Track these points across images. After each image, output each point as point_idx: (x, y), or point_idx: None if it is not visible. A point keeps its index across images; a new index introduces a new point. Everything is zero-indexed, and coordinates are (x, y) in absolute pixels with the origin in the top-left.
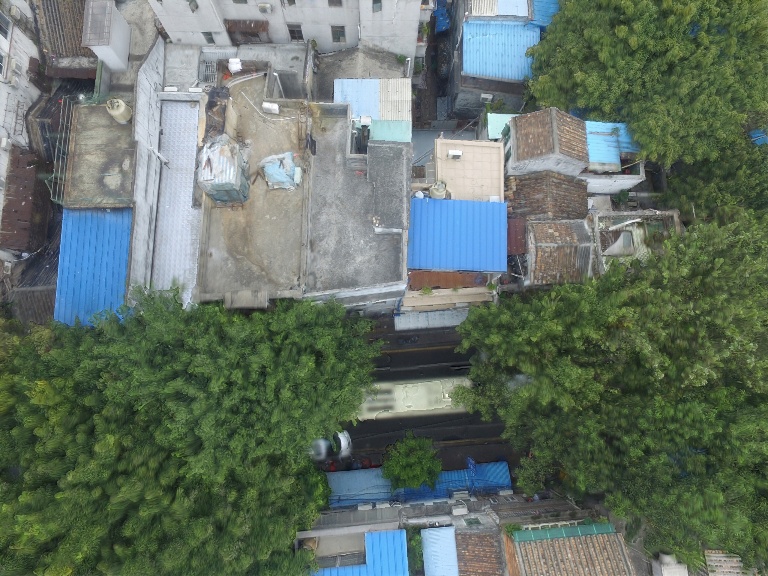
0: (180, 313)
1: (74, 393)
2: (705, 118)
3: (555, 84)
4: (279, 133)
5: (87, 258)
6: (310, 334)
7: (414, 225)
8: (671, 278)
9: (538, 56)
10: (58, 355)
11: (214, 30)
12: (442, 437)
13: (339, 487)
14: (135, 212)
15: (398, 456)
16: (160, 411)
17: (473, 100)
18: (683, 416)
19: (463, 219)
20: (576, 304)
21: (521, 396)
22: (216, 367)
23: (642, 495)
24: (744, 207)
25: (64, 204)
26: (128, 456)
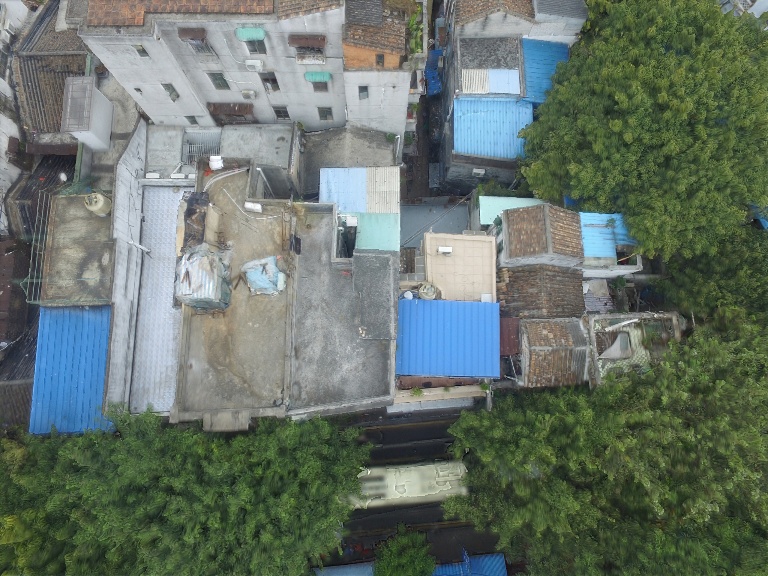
0: (156, 442)
1: (46, 524)
2: (703, 213)
3: (548, 170)
4: (262, 233)
5: (65, 359)
6: (293, 457)
7: (403, 328)
8: None
9: (530, 139)
10: (29, 483)
11: (197, 114)
12: (437, 518)
13: None
14: (114, 314)
15: (390, 555)
16: (135, 547)
17: (465, 173)
18: (685, 554)
19: (454, 321)
20: (571, 423)
21: (515, 522)
22: (192, 510)
23: None
24: (745, 306)
25: (41, 303)
26: None
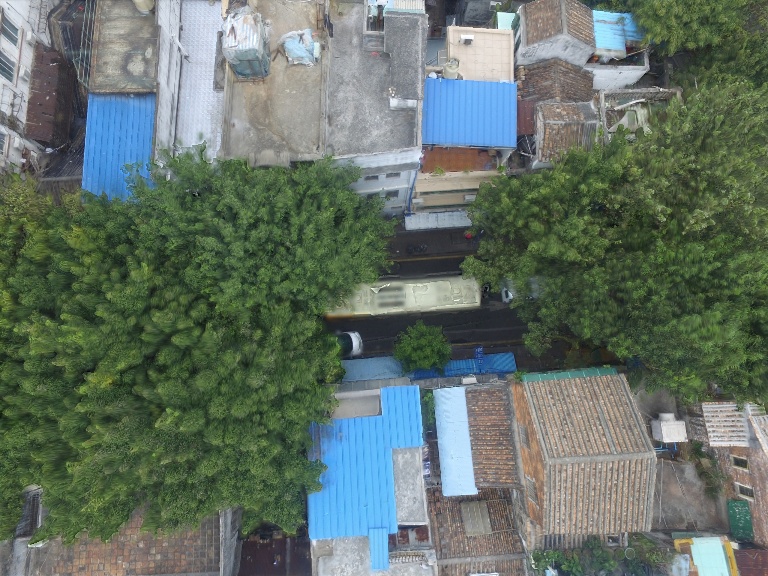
0: (207, 165)
1: (106, 245)
2: (708, 3)
3: None
4: (298, 14)
5: (112, 140)
6: (330, 192)
7: (428, 103)
8: (674, 141)
9: None
10: (90, 209)
11: None
12: (450, 340)
13: (352, 374)
14: (159, 93)
15: (409, 340)
16: (189, 257)
17: (482, 10)
18: (684, 257)
19: (475, 98)
20: (583, 165)
21: (530, 250)
22: (244, 206)
23: (644, 335)
24: None
25: (90, 88)
26: (160, 294)
